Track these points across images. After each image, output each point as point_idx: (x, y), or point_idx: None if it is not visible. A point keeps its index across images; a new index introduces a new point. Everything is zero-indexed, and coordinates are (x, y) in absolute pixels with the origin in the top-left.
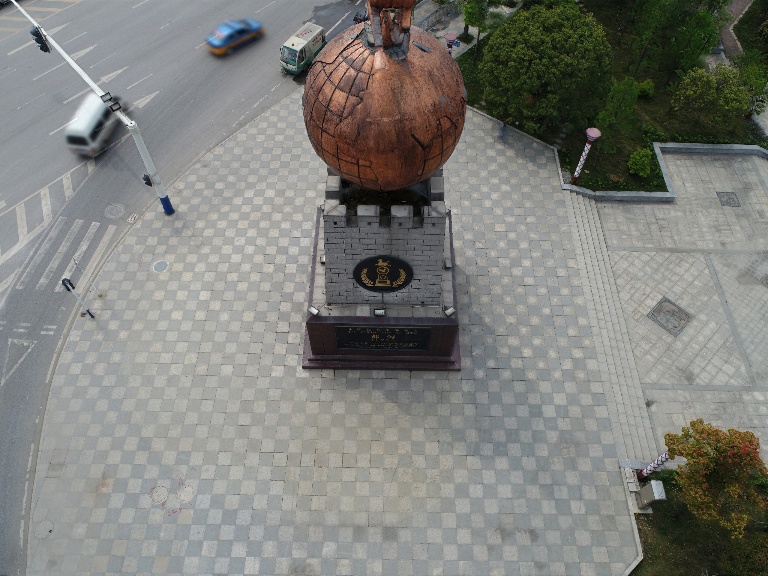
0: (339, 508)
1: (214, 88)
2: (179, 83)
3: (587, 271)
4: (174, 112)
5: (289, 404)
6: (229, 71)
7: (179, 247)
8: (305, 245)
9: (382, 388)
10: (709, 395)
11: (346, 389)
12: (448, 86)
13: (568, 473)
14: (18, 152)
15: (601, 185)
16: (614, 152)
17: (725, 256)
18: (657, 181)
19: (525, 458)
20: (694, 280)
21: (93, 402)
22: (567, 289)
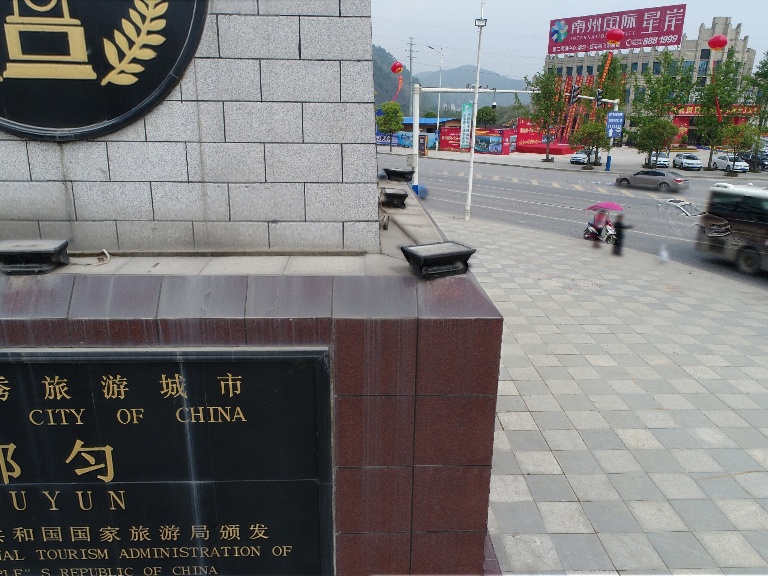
0: None
1: None
2: None
3: None
4: None
5: None
6: None
7: None
8: None
9: None
10: None
11: None
12: None
13: None
14: None
15: None
16: None
17: None
18: None
19: None
20: None
21: None
22: None
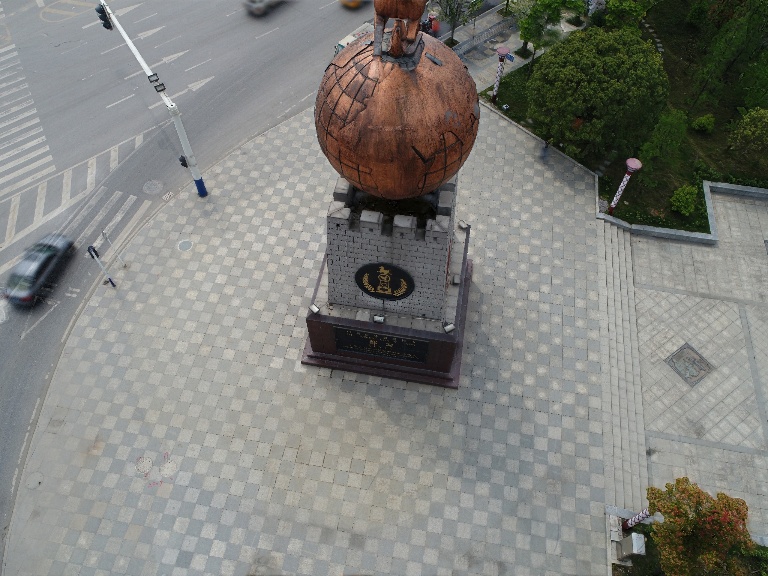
0: (312, 507)
1: (266, 79)
2: (234, 70)
3: (607, 305)
4: (225, 98)
5: (282, 397)
6: (284, 63)
7: (206, 229)
8: None
9: (376, 394)
10: (717, 453)
11: (340, 390)
12: (457, 101)
13: (549, 510)
14: (75, 121)
15: (639, 218)
16: (659, 186)
17: (762, 309)
18: (700, 221)
19: (507, 488)
20: (723, 330)
21: (100, 367)
22: (583, 321)
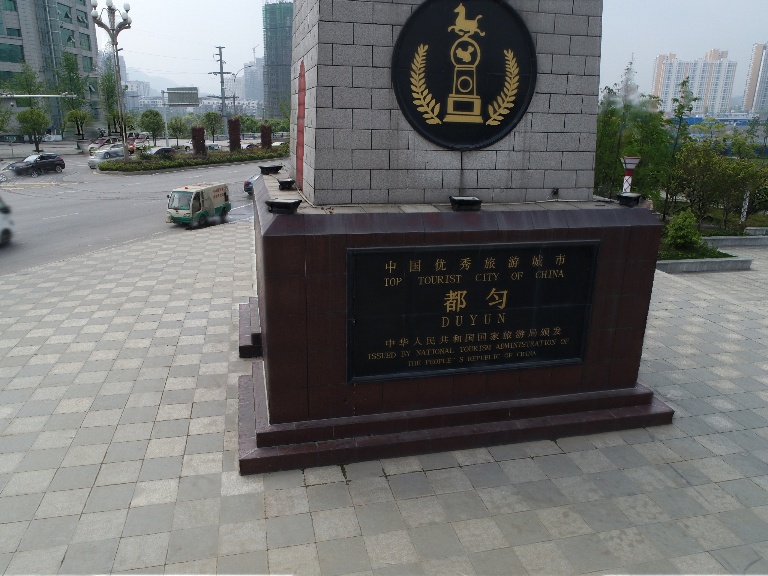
0: None
1: (63, 235)
2: (6, 234)
3: None
4: None
5: (201, 568)
6: (90, 227)
7: None
8: (220, 316)
9: (501, 480)
10: None
11: (394, 499)
12: None
13: None
14: None
15: None
16: None
17: None
18: None
19: None
20: None
21: None
22: (733, 315)
